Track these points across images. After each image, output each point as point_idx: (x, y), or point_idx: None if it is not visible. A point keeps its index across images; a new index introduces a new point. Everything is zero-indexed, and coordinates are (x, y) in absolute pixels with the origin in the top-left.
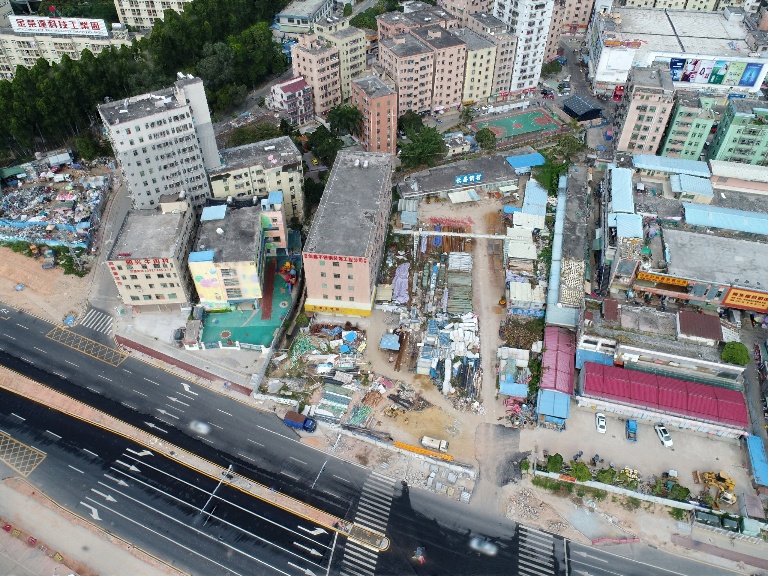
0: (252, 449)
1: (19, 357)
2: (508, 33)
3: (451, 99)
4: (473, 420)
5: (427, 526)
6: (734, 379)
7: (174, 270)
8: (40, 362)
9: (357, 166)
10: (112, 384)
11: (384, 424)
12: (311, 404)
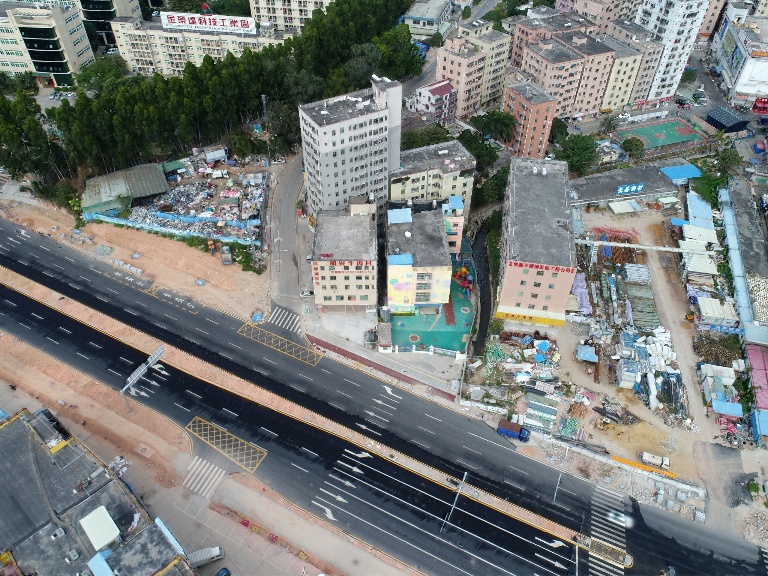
0: (470, 456)
1: (217, 352)
2: (653, 41)
3: (591, 106)
4: (687, 437)
5: (667, 545)
6: None
7: (374, 272)
8: (238, 358)
9: (536, 173)
10: (314, 383)
11: (596, 437)
12: (518, 413)
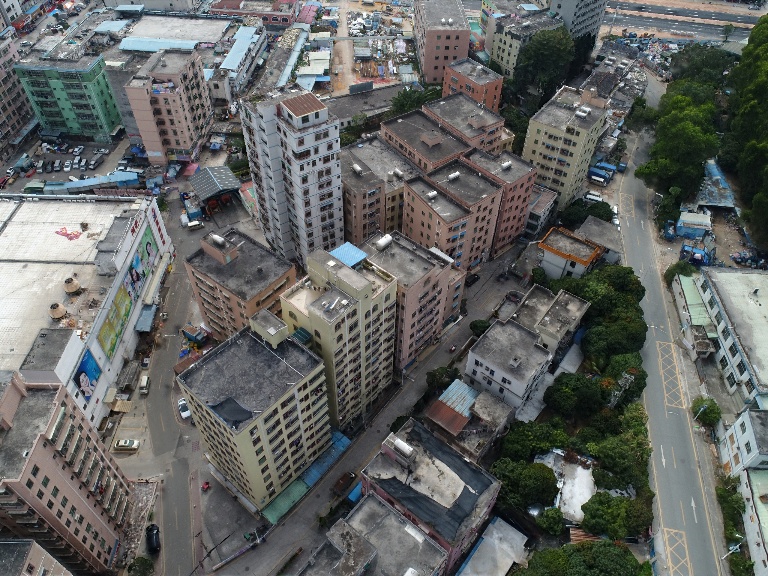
0: None
1: None
2: None
3: None
4: None
5: None
6: None
7: None
8: None
9: None
10: None
11: None
12: None
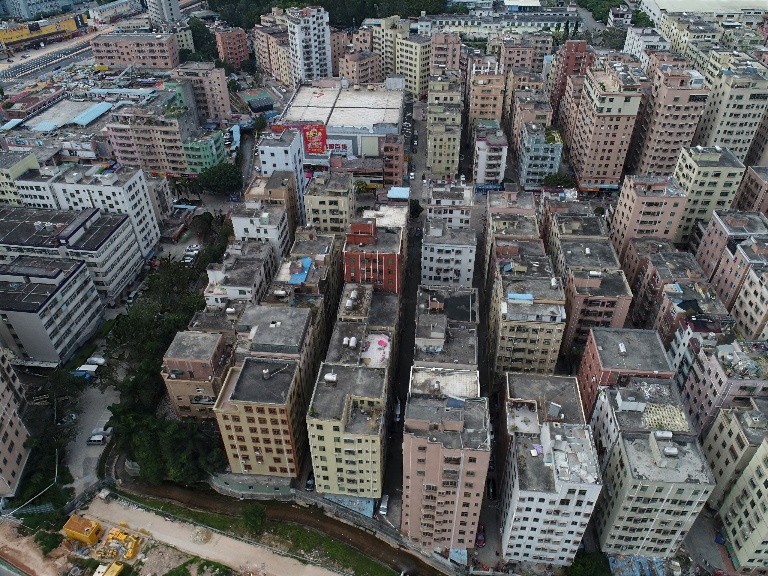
0: None
1: None
2: None
3: None
4: None
5: (5, 86)
6: (6, 116)
7: None
8: None
9: None
10: None
11: None
12: None
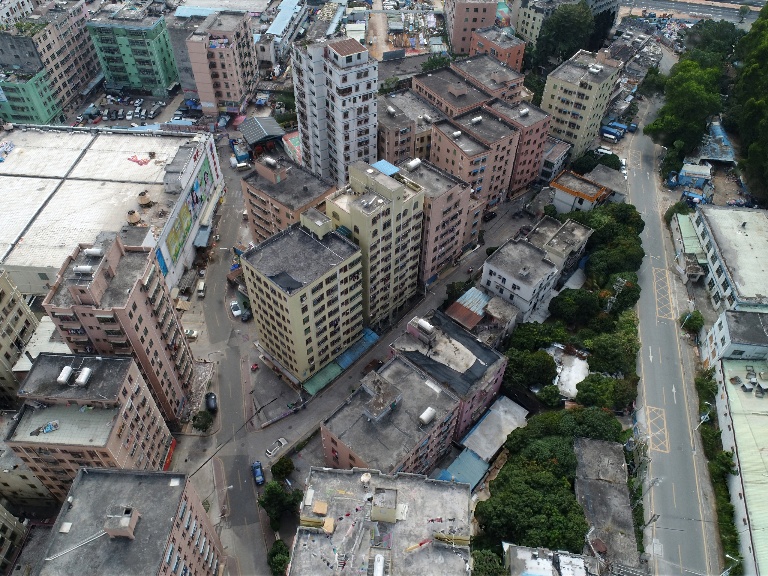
0: None
1: None
2: None
3: None
4: None
5: None
6: None
7: None
8: None
9: None
10: None
11: None
12: None
